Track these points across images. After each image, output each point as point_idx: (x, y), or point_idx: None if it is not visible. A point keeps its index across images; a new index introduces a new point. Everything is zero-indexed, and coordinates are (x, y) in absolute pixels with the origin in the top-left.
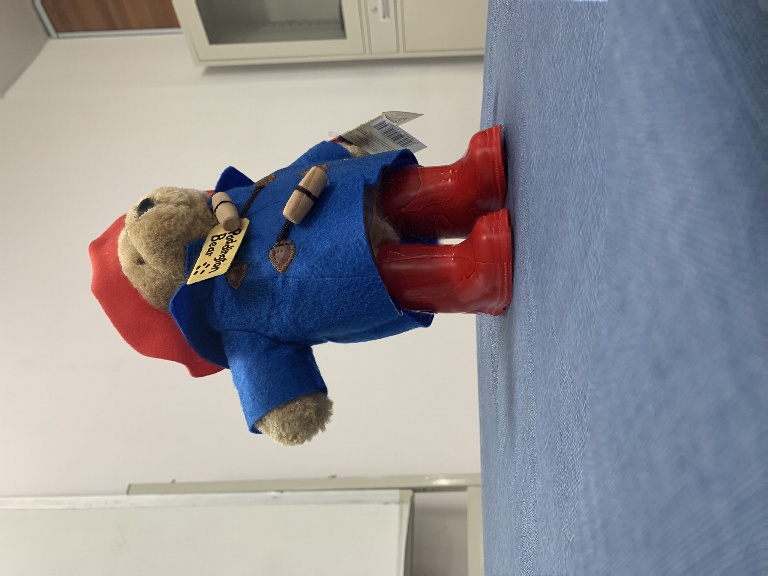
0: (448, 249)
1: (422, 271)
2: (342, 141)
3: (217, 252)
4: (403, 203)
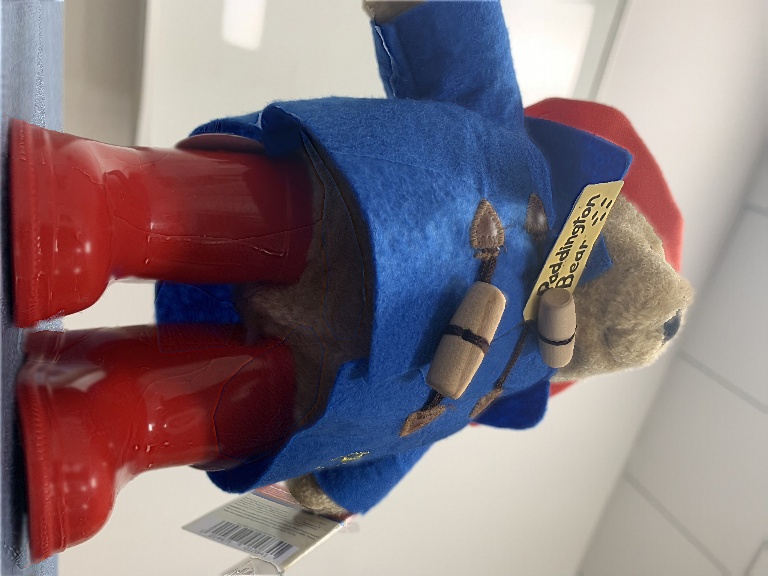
0: (161, 254)
1: (218, 208)
2: (337, 516)
3: (576, 246)
4: (228, 406)
